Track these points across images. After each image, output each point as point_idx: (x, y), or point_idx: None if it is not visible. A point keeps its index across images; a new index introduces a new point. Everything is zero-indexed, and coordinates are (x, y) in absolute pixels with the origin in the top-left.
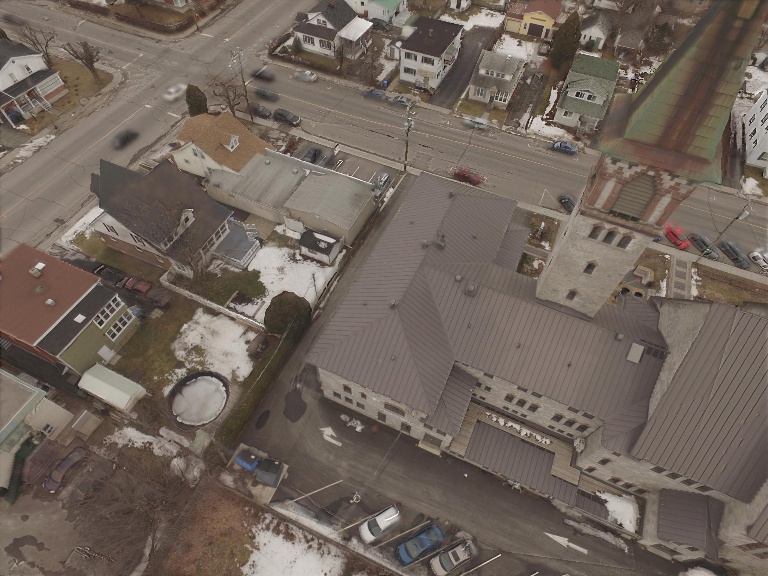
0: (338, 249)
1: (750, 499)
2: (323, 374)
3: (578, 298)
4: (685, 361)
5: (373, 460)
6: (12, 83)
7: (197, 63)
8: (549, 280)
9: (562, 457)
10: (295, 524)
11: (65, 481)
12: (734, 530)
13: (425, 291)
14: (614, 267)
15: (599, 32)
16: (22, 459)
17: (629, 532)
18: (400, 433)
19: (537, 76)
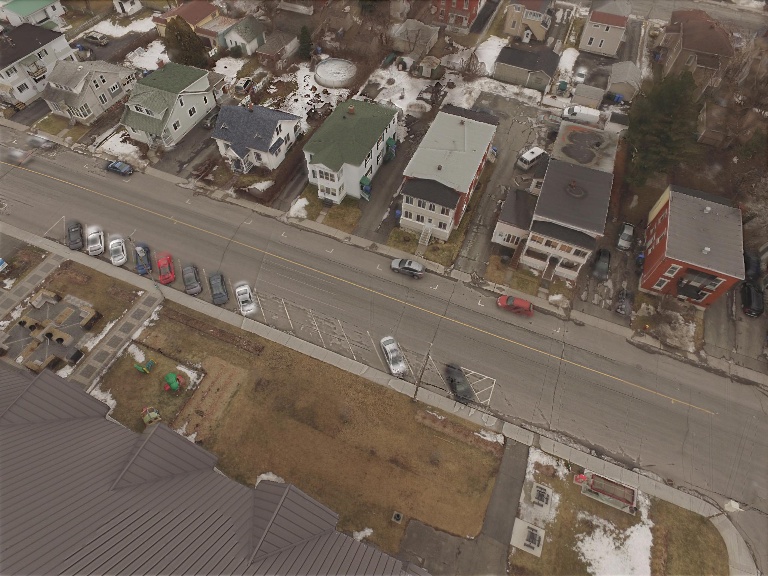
0: None
1: None
2: None
3: None
4: None
5: None
6: None
7: None
8: None
9: None
10: None
11: None
12: None
13: None
14: None
15: (239, 37)
16: None
17: None
18: None
19: None
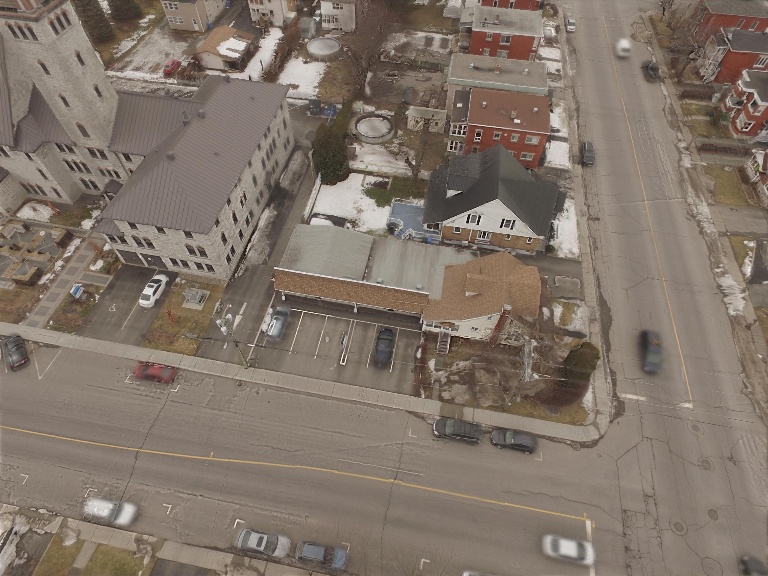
0: None
1: None
2: None
3: None
4: None
5: None
6: None
7: (737, 574)
8: None
9: None
10: (296, 98)
11: None
12: None
13: None
14: None
15: None
16: None
17: None
18: None
19: None
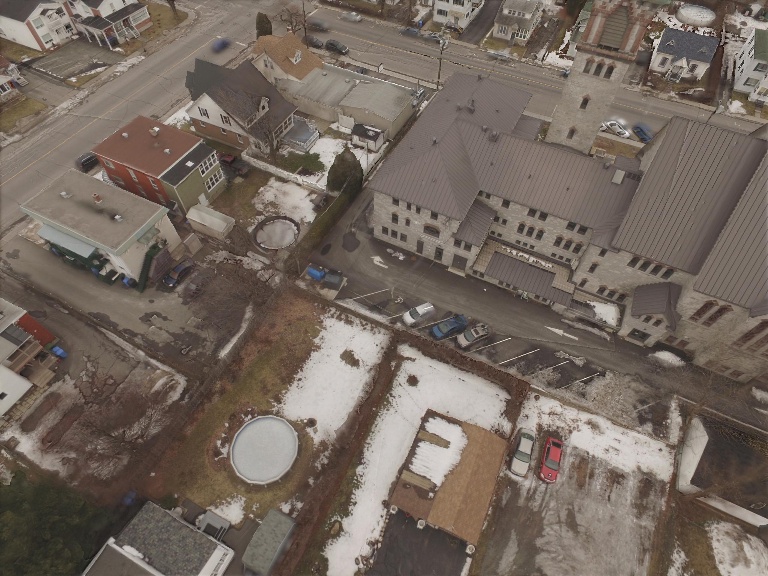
0: (382, 140)
1: (698, 271)
2: (377, 205)
3: (576, 136)
4: (652, 165)
5: (412, 278)
6: (111, 12)
7: (258, 6)
8: (554, 121)
9: (561, 276)
10: (354, 312)
11: (179, 280)
12: (686, 296)
13: (458, 138)
14: (602, 98)
15: None
16: (151, 257)
17: (611, 326)
18: (434, 262)
19: (553, 20)
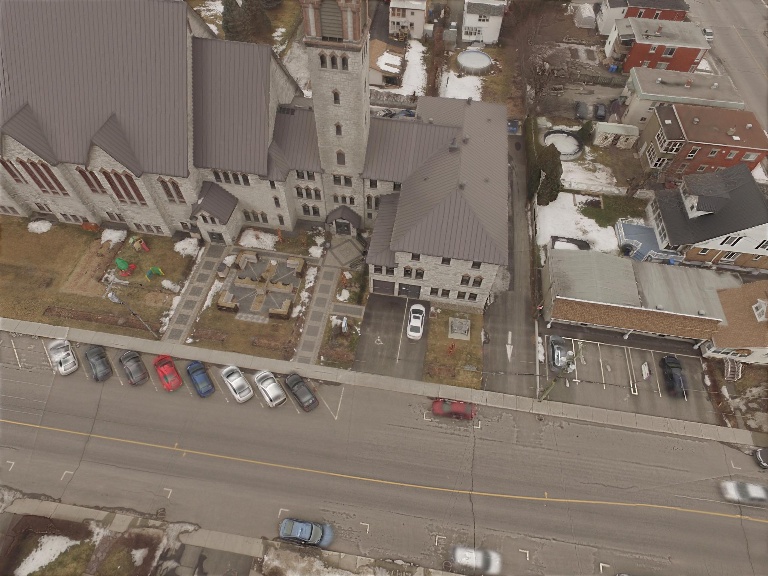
0: None
1: None
2: None
3: None
4: None
5: None
6: None
7: None
8: None
9: None
10: None
11: None
12: None
13: None
14: None
15: None
16: None
17: None
18: None
19: None
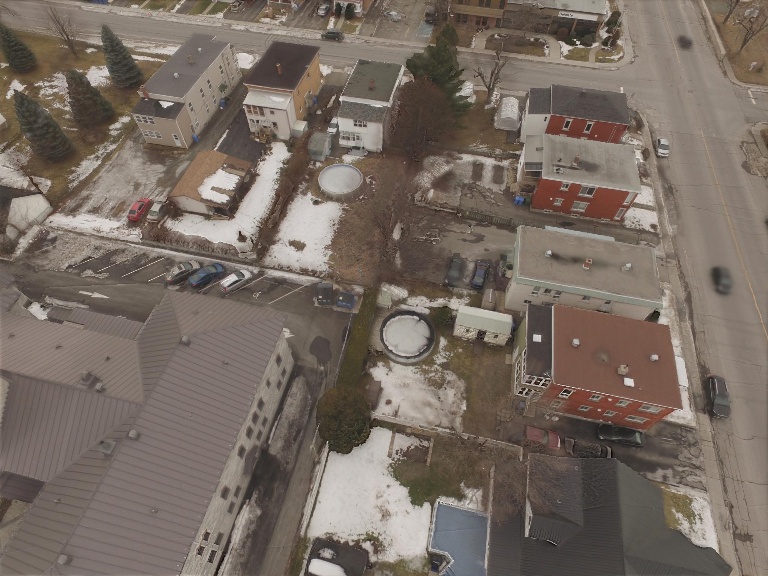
0: None
1: None
2: None
3: None
4: None
5: None
6: None
7: None
8: None
9: None
10: (300, 273)
11: None
12: None
13: None
14: None
15: None
16: None
17: None
18: None
19: None
